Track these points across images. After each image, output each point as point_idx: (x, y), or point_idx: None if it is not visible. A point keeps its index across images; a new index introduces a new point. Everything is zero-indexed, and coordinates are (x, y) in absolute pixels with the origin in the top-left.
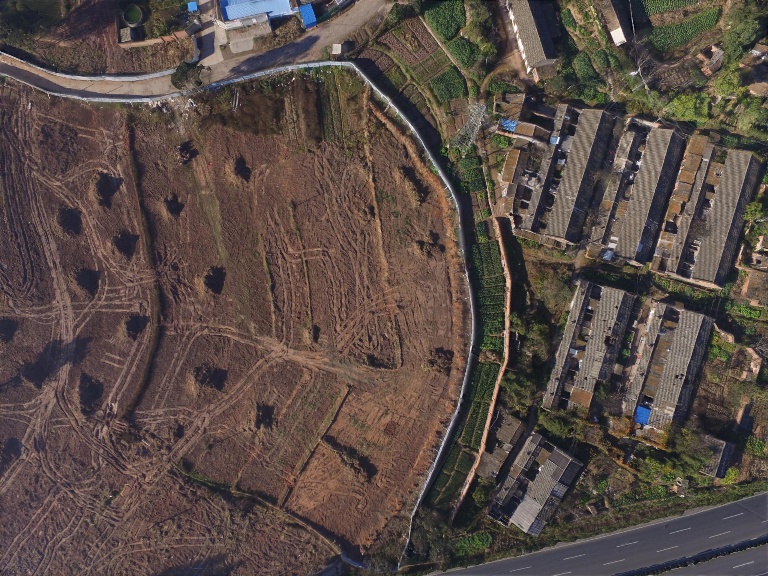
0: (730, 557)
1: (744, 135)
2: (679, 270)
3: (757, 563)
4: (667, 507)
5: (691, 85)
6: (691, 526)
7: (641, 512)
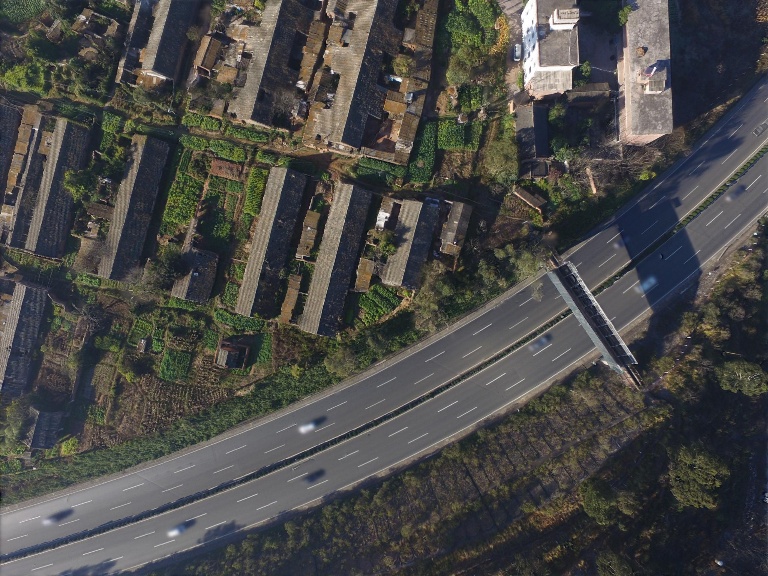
0: (131, 528)
1: (85, 102)
2: (16, 242)
3: (158, 533)
4: (37, 480)
5: (25, 55)
6: (92, 499)
7: (13, 486)
